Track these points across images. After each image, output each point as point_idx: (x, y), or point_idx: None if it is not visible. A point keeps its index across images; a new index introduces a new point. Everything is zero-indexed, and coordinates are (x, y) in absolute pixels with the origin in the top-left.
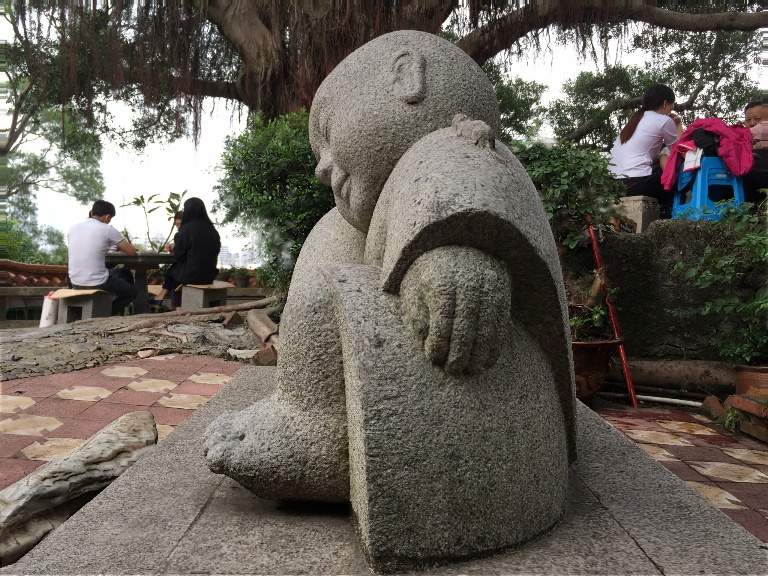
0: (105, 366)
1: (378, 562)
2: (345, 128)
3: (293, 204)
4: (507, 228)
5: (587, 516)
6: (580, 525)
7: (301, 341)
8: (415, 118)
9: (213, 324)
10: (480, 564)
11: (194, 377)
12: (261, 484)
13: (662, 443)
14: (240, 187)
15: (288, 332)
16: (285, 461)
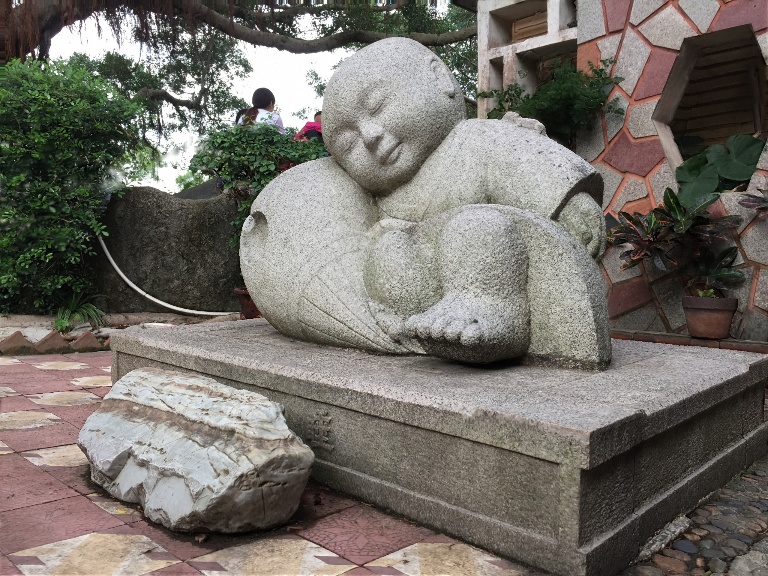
0: None
1: (599, 366)
2: (414, 108)
3: None
4: (602, 183)
5: None
6: None
7: (506, 252)
8: (454, 108)
9: None
10: None
11: None
12: (497, 348)
13: None
14: None
15: (492, 247)
16: (507, 331)
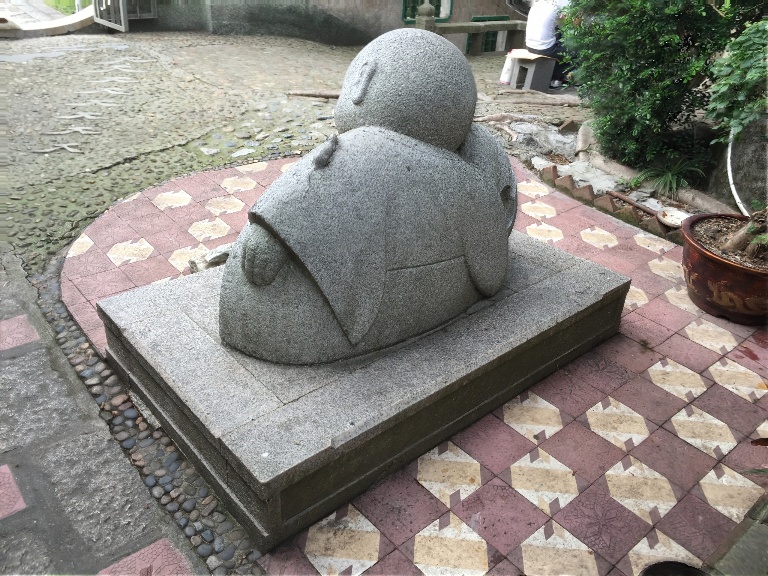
0: None
1: (222, 340)
2: None
3: (597, 41)
4: (269, 226)
5: (333, 371)
6: (319, 371)
7: None
8: (355, 114)
9: (552, 127)
10: (252, 360)
11: None
12: None
13: (722, 384)
14: (565, 15)
15: None
16: None
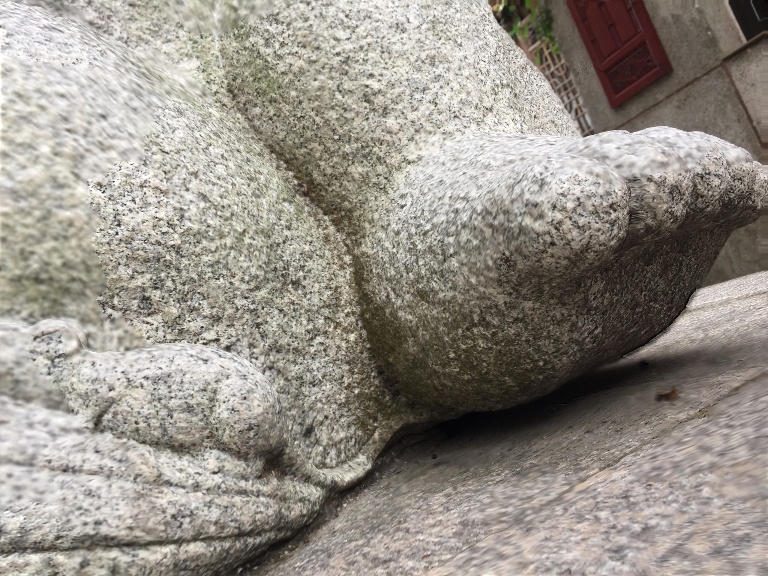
0: None
1: None
2: None
3: None
4: None
5: None
6: None
7: None
8: None
9: None
10: None
11: None
12: None
13: None
14: None
15: None
16: None
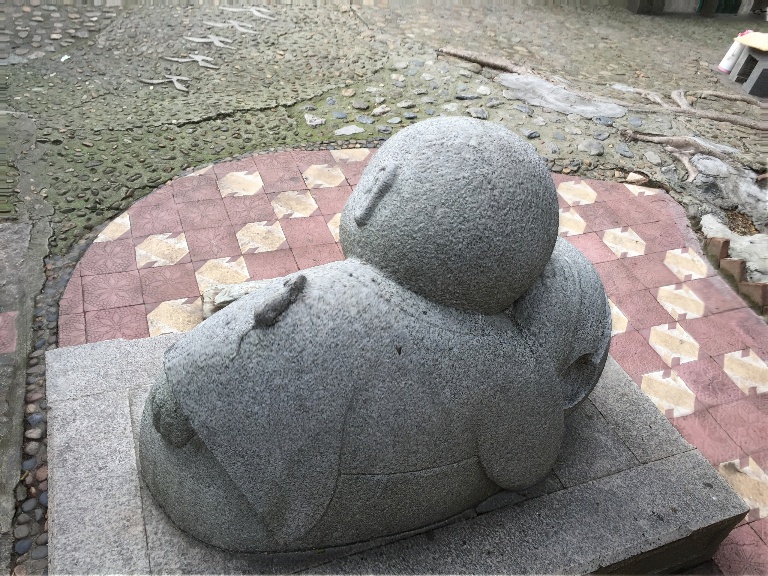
0: (576, 177)
1: None
2: None
3: None
4: None
5: (248, 569)
6: (229, 564)
7: None
8: None
9: (749, 172)
10: (160, 514)
11: (613, 232)
12: None
13: None
14: None
15: None
16: None
